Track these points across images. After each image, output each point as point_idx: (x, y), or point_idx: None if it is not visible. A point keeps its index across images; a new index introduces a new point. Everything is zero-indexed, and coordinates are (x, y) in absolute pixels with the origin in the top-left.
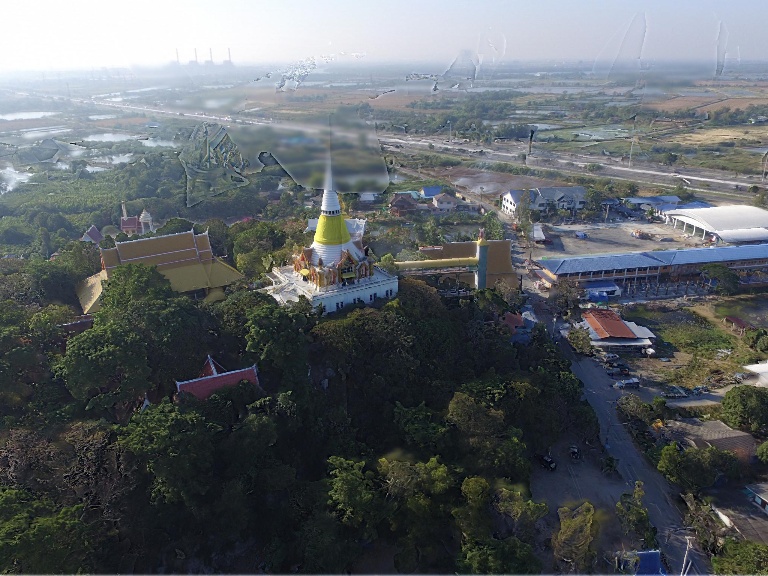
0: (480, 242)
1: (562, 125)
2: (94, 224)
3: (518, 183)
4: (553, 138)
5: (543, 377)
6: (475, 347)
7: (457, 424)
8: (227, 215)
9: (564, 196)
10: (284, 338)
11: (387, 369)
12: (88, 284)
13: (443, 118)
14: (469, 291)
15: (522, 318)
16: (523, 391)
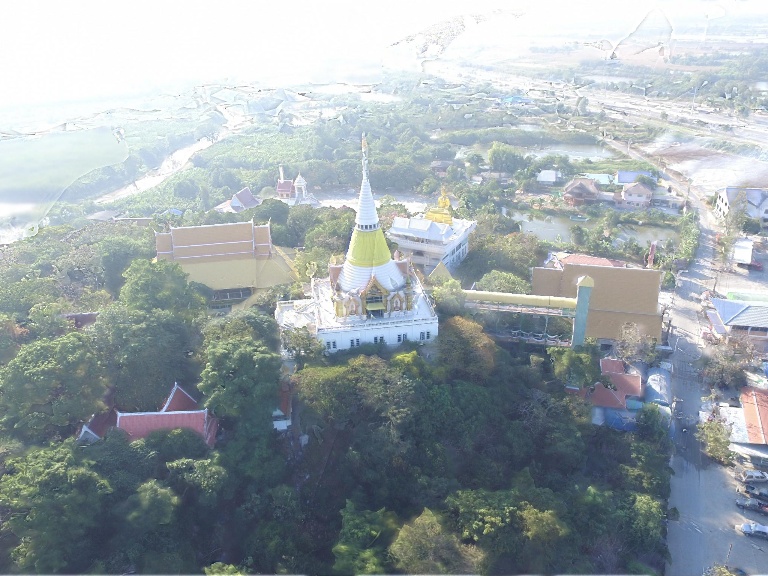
0: (580, 281)
1: None
2: (261, 183)
3: (760, 173)
4: None
5: (591, 504)
6: (526, 427)
7: (401, 560)
8: (384, 185)
9: None
10: (234, 387)
11: (367, 445)
12: None
13: (698, 78)
14: None
15: (645, 383)
16: (532, 528)
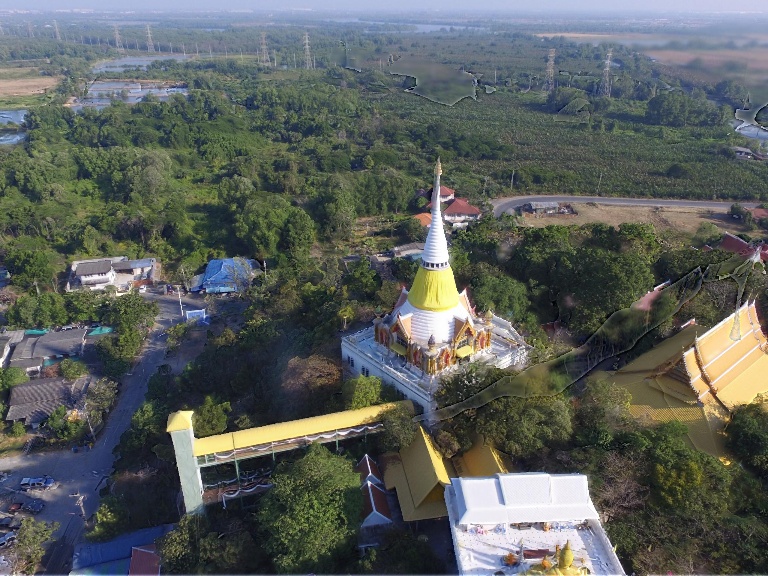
0: None
1: None
2: None
3: None
4: None
5: None
6: None
7: None
8: None
9: None
10: None
11: None
12: None
13: None
14: (216, 500)
15: None
16: None
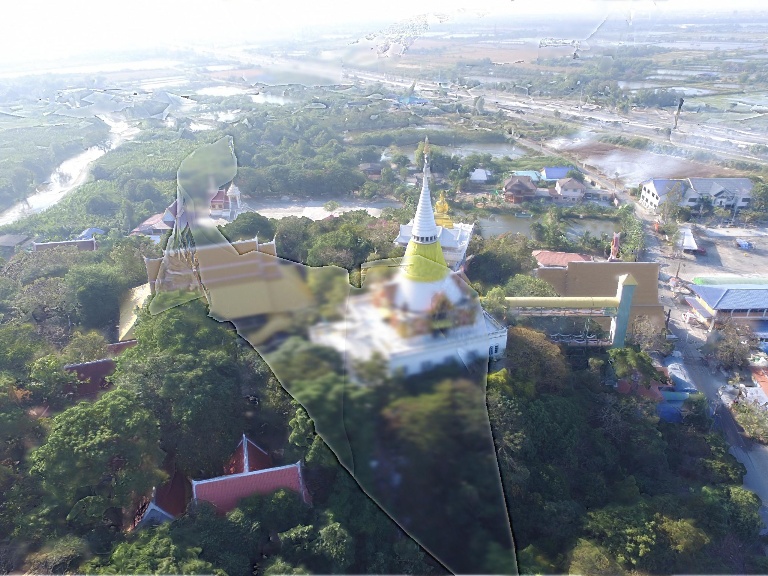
0: (624, 279)
1: (714, 90)
2: None
3: (660, 165)
4: (704, 107)
5: (709, 504)
6: (606, 433)
7: None
8: (321, 191)
9: (724, 191)
10: None
11: None
12: (133, 297)
13: (572, 79)
14: (601, 338)
15: None
16: (682, 541)
